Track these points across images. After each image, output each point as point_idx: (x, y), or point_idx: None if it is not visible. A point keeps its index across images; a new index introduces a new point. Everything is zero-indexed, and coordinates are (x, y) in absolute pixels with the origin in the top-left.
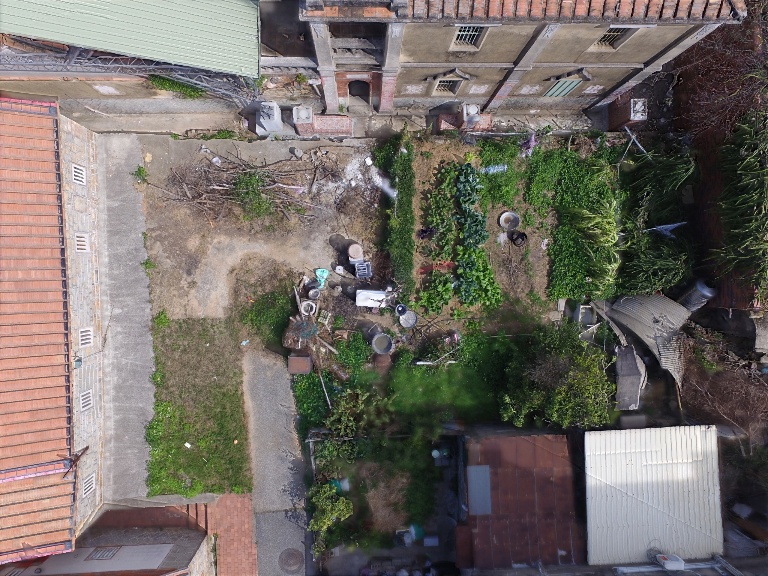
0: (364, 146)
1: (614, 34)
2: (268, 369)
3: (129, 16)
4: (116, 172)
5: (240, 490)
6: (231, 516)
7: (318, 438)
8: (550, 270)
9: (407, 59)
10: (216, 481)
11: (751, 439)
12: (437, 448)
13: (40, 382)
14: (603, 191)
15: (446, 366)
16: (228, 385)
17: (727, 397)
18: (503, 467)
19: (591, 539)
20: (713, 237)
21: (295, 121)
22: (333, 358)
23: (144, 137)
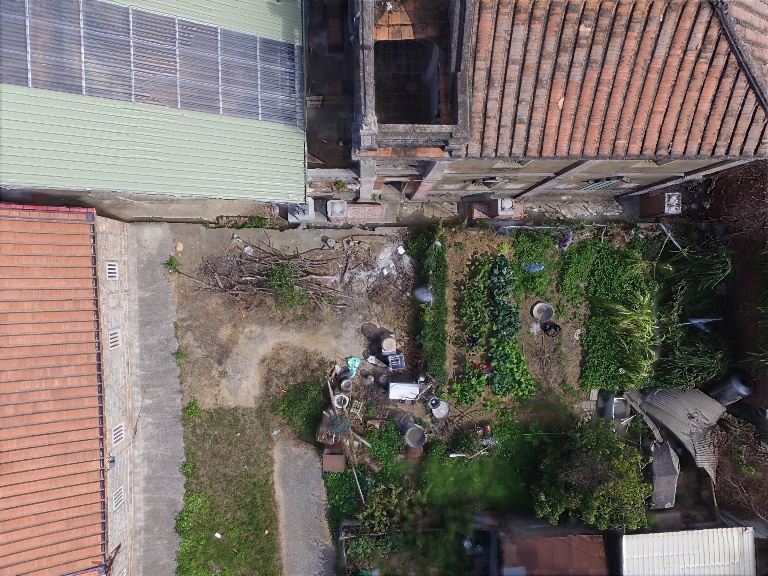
0: (396, 235)
1: None
2: (299, 458)
3: (181, 156)
4: (147, 262)
5: None
6: None
7: (352, 534)
8: (583, 360)
9: (449, 171)
10: (246, 571)
11: None
12: None
13: (75, 490)
14: (636, 283)
15: (479, 456)
16: (259, 475)
17: (762, 495)
18: (540, 569)
19: None
20: (748, 333)
21: (329, 215)
22: (366, 451)
23: (175, 226)
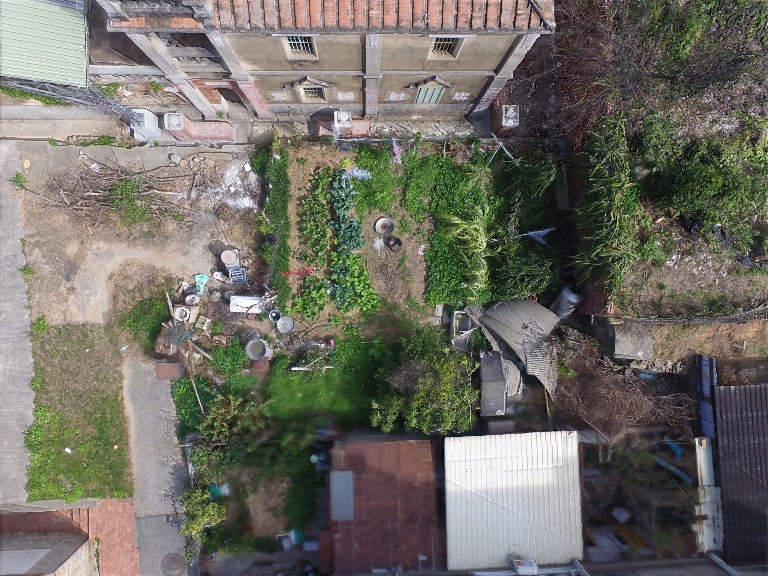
0: (243, 152)
1: (447, 43)
2: (148, 374)
3: None
4: None
5: (121, 495)
6: (113, 521)
7: (189, 444)
8: (427, 276)
9: (253, 67)
10: (97, 486)
11: (611, 445)
12: (316, 453)
13: None
14: (478, 197)
15: (324, 371)
16: (108, 390)
17: (594, 403)
18: (366, 473)
19: (451, 544)
20: (581, 243)
21: (166, 128)
22: (208, 364)
23: (22, 143)
